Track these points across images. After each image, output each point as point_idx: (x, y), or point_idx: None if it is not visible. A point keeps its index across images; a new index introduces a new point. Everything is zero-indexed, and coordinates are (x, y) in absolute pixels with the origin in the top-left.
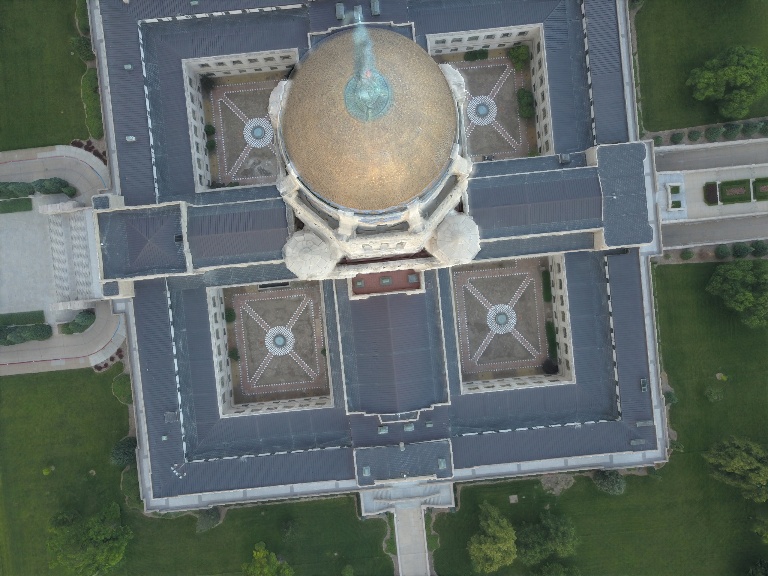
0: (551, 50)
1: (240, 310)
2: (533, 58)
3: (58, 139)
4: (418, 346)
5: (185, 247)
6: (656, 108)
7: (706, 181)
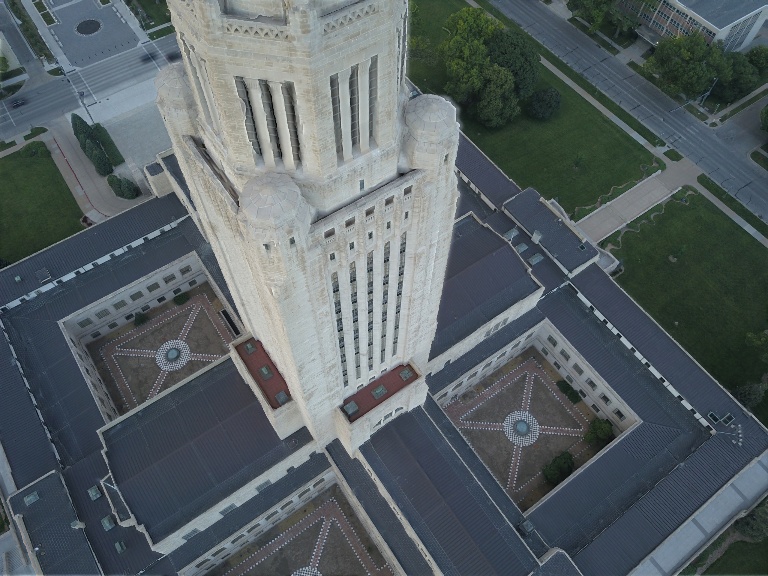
0: (625, 447)
1: (191, 305)
2: None
3: None
4: (213, 469)
5: None
6: None
7: None
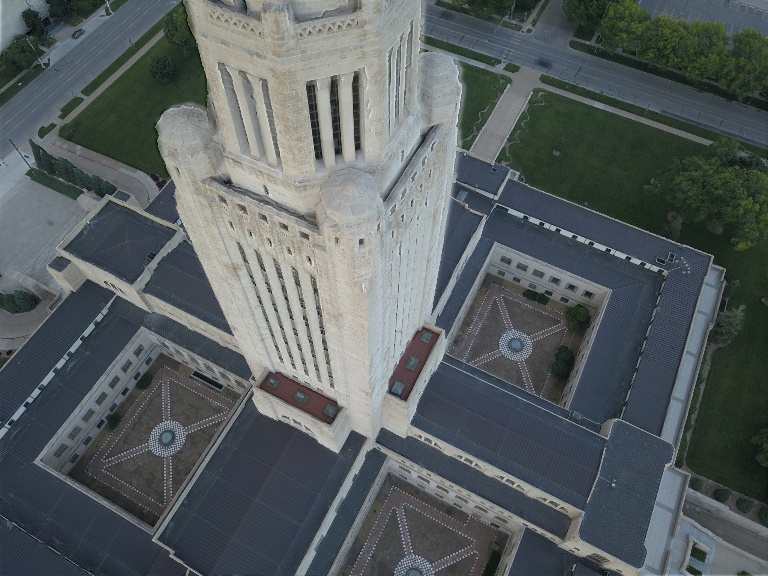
0: (610, 316)
1: (158, 383)
2: (590, 325)
3: (145, 167)
4: (290, 512)
5: (150, 264)
6: (707, 450)
7: (744, 569)
